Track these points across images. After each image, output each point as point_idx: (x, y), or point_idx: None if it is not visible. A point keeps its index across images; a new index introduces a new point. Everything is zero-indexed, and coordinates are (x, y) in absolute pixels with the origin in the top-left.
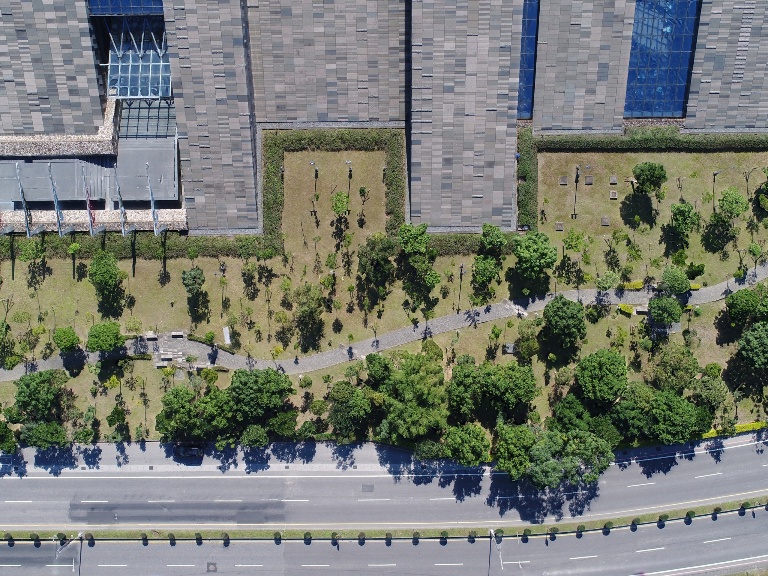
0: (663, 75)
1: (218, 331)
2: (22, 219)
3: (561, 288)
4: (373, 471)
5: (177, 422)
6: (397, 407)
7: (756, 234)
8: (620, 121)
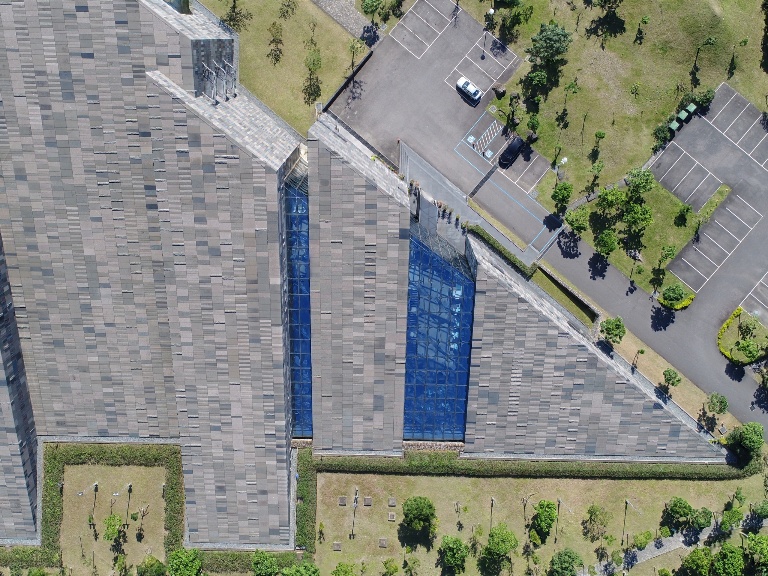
0: (451, 390)
1: None
2: None
3: None
4: None
5: None
6: None
7: (532, 560)
8: (400, 444)
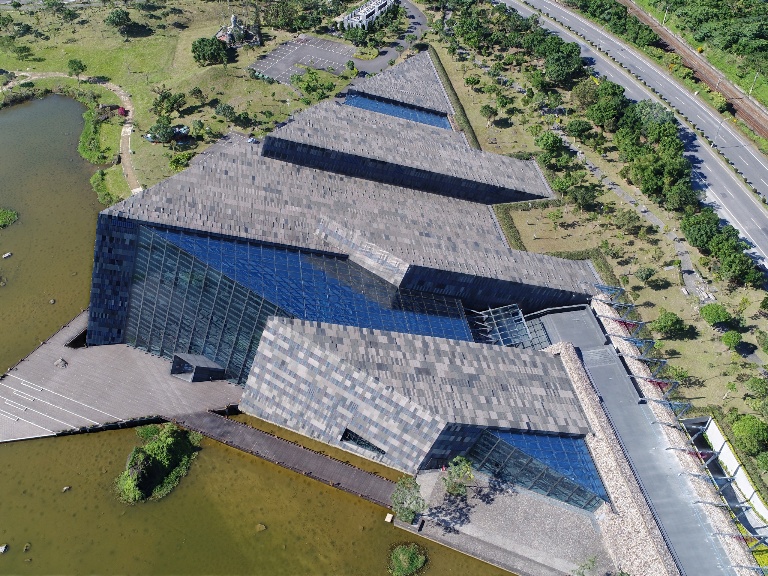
0: None
1: (670, 273)
2: (653, 392)
3: None
4: (712, 195)
5: (748, 259)
6: (669, 165)
7: None
8: (457, 132)
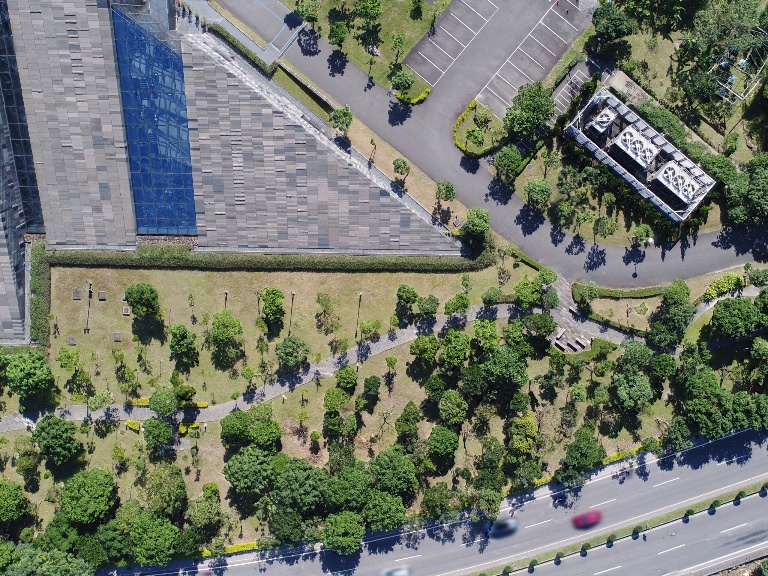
0: None
1: None
2: None
3: (71, 402)
4: None
5: None
6: None
7: (266, 353)
8: (133, 238)
